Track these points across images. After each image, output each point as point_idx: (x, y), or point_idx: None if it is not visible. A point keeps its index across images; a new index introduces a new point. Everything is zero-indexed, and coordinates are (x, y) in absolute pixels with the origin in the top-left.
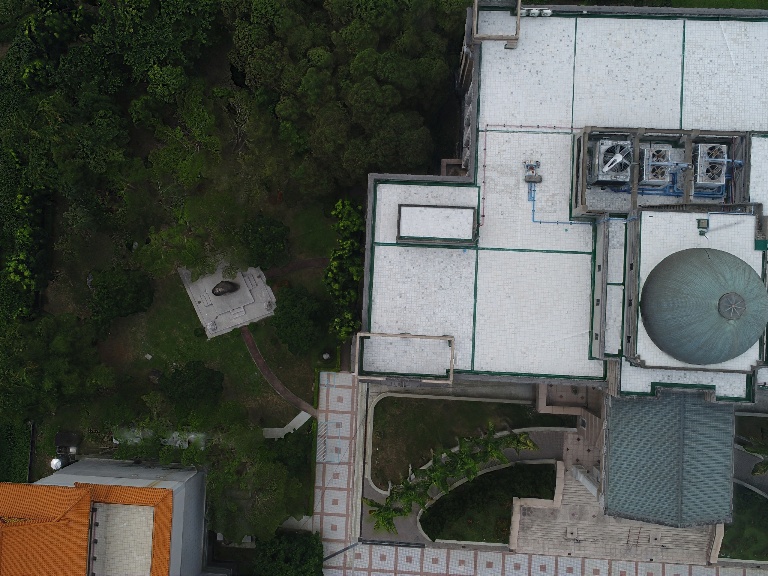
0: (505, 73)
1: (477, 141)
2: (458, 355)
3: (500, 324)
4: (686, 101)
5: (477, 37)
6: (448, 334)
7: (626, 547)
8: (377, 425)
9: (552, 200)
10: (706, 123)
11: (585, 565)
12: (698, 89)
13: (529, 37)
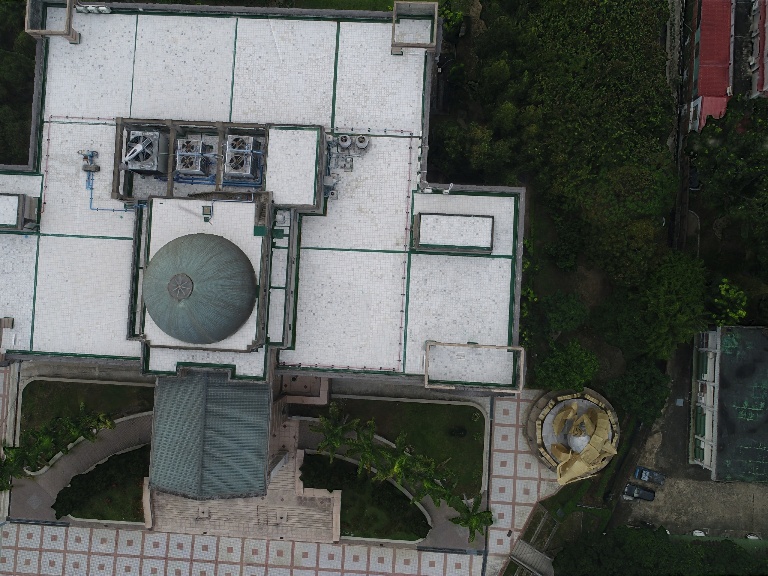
0: (70, 67)
1: (42, 132)
2: (18, 336)
3: (57, 307)
4: (236, 95)
5: (29, 32)
6: (9, 316)
7: (258, 526)
8: (26, 408)
9: (109, 188)
10: (253, 116)
11: (220, 543)
12: (247, 84)
13: (93, 33)
